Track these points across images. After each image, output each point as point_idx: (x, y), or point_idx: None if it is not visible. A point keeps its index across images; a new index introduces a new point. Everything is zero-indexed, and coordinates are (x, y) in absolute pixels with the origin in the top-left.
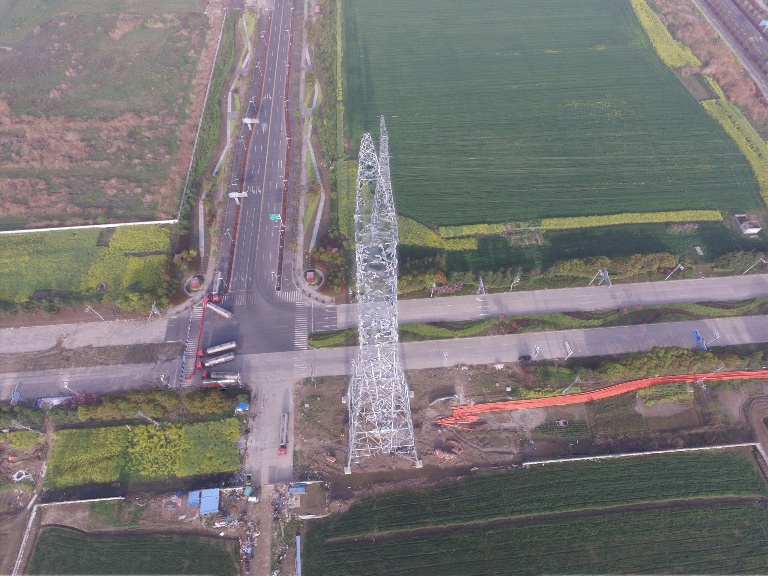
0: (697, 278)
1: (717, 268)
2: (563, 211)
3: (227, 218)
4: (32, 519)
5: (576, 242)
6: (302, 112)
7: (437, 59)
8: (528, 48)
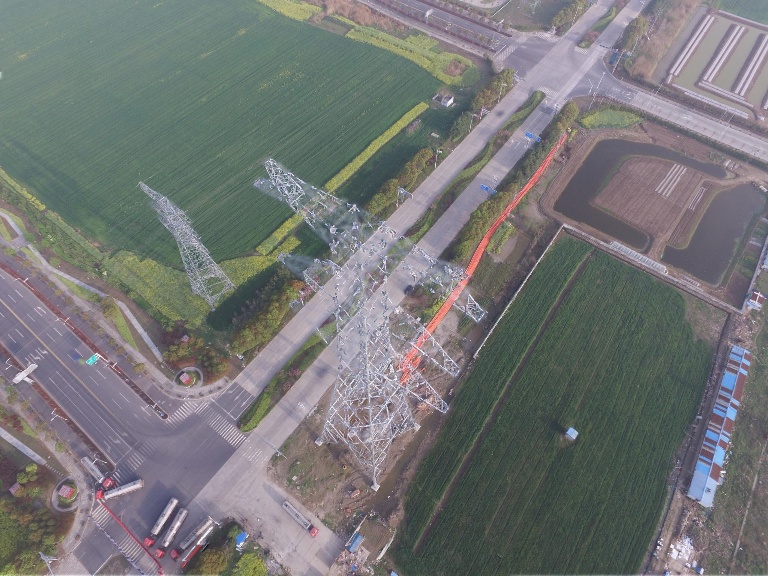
0: (450, 153)
1: (454, 139)
2: (332, 169)
3: (33, 406)
4: None
5: (362, 184)
6: (11, 247)
7: (109, 115)
8: (184, 62)
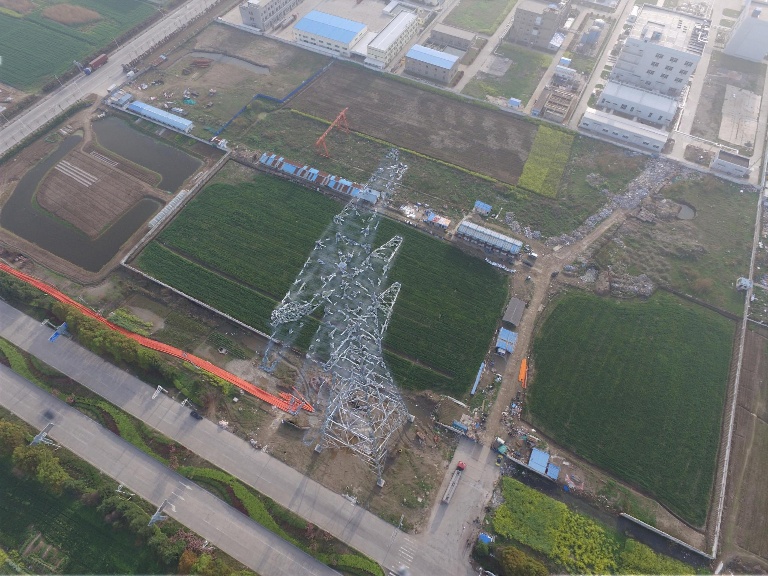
0: None
1: None
2: None
3: None
4: (715, 545)
5: (5, 508)
6: None
7: None
8: None
